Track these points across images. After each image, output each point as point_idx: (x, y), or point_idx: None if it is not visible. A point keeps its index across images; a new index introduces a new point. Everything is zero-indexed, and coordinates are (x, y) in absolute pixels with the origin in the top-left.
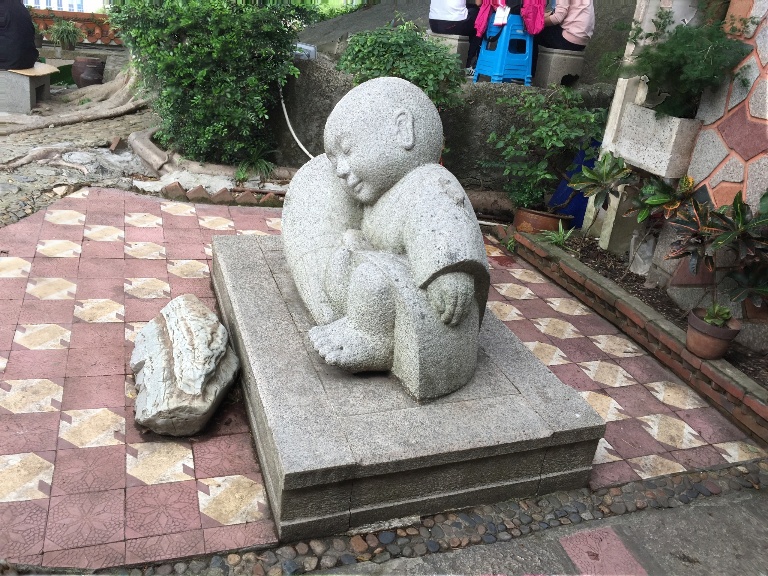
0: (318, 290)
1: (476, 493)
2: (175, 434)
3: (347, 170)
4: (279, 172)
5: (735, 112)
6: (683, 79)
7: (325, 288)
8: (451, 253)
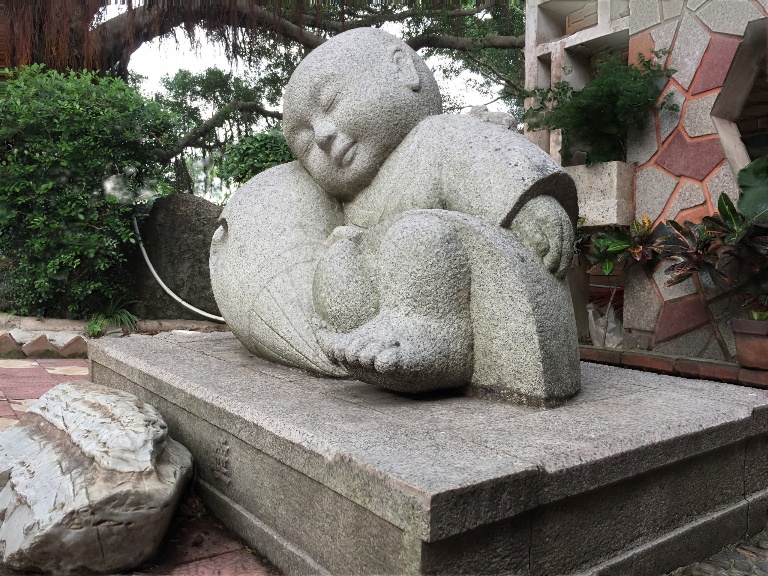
0: (304, 319)
1: (687, 536)
2: (101, 567)
3: (332, 130)
4: (146, 324)
5: (671, 141)
6: (621, 105)
7: (319, 307)
8: (537, 165)
